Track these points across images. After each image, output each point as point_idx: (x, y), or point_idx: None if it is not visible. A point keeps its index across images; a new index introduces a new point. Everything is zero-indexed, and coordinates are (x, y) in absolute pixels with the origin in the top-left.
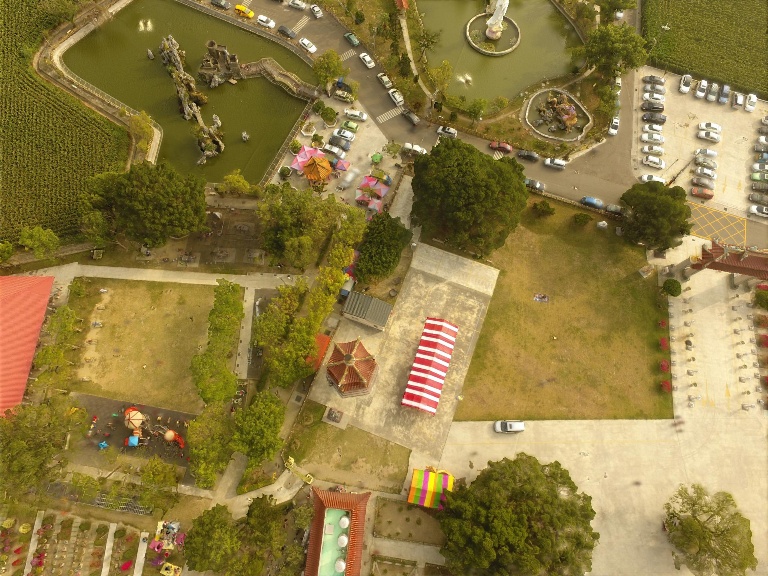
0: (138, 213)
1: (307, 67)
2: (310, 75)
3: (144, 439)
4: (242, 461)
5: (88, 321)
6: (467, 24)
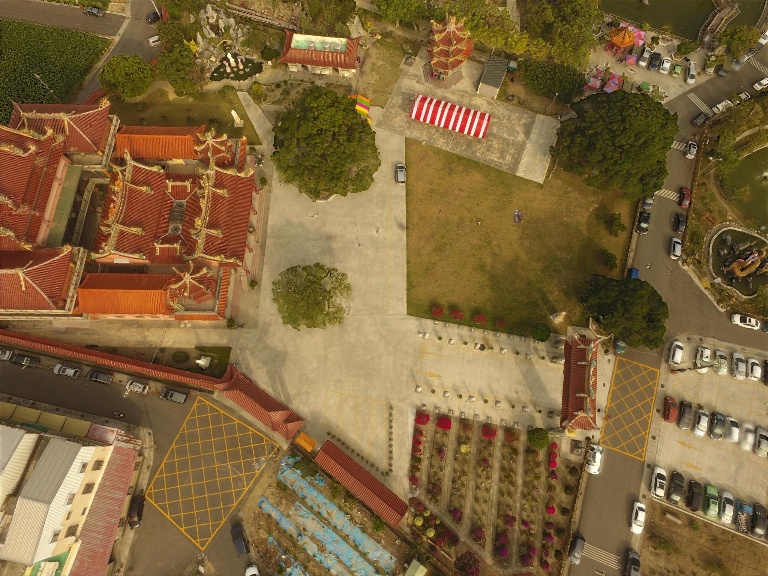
0: None
1: None
2: None
3: None
4: None
5: None
6: None
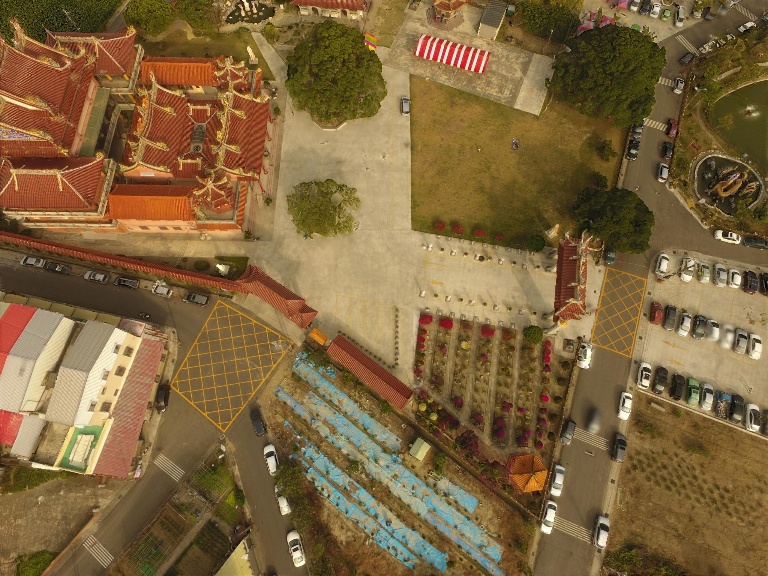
0: None
1: None
2: None
3: None
4: None
5: None
6: None
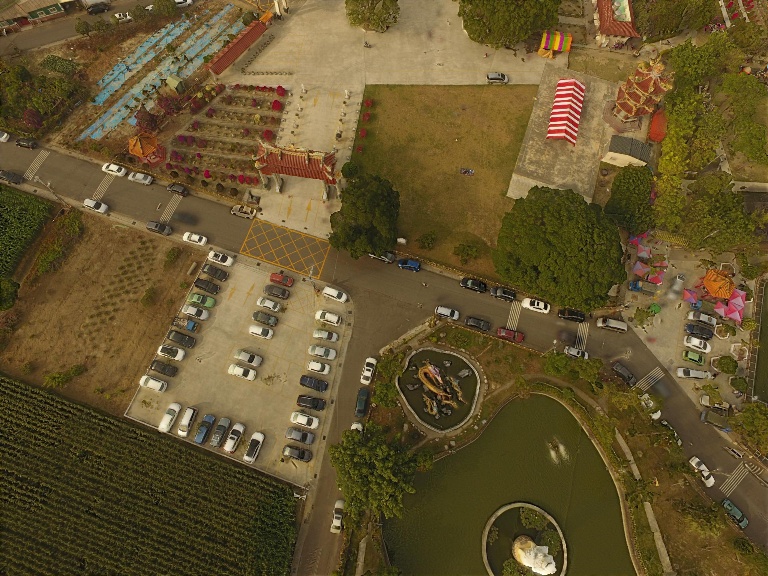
0: None
1: None
2: None
3: (761, 74)
4: None
5: None
6: (568, 568)
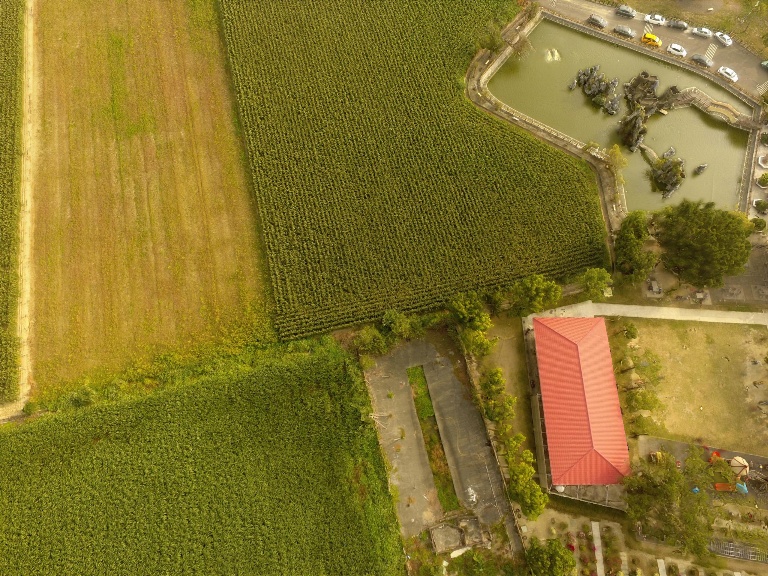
0: (704, 254)
1: (730, 96)
2: (736, 104)
3: None
4: None
5: (627, 361)
6: None
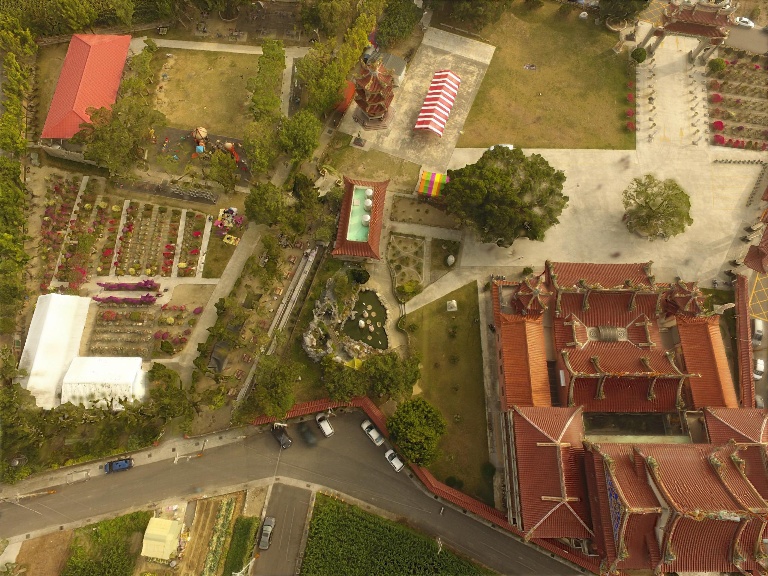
0: None
1: None
2: None
3: (207, 152)
4: (285, 172)
5: (158, 76)
6: None
